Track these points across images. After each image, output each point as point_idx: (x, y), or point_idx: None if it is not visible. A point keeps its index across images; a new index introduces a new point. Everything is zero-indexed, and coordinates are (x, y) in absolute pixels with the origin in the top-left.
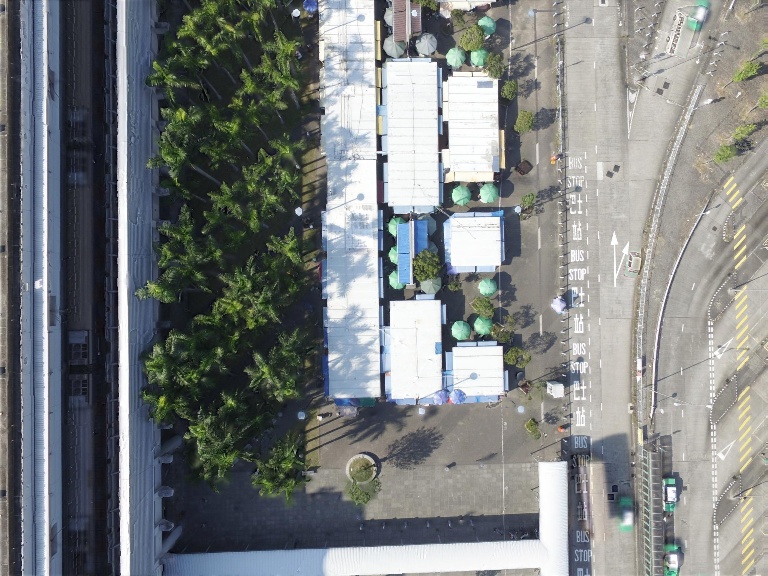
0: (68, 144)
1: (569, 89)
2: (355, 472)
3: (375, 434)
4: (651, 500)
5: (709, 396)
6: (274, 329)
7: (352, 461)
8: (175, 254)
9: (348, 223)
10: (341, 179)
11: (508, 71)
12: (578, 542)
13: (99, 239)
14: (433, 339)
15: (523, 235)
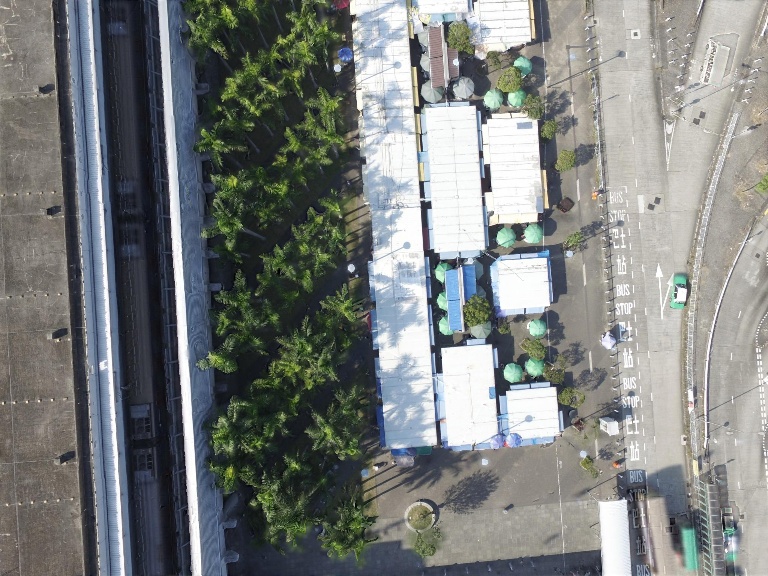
0: (118, 215)
1: (606, 123)
2: (414, 520)
3: (431, 481)
4: (711, 532)
5: (761, 423)
6: (330, 386)
7: (410, 509)
8: (232, 320)
9: (395, 272)
10: (386, 228)
11: (545, 109)
12: None
13: (154, 309)
14: (486, 384)
15: (568, 272)
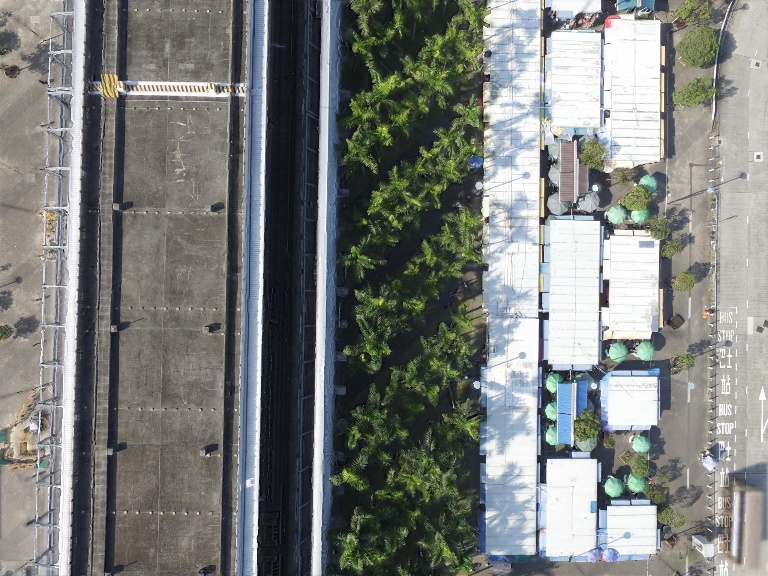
0: None
1: (722, 243)
2: None
3: None
4: None
5: None
6: (443, 495)
7: None
8: (362, 433)
9: (508, 381)
10: (503, 337)
11: None
12: None
13: (286, 414)
14: (589, 498)
15: (673, 389)
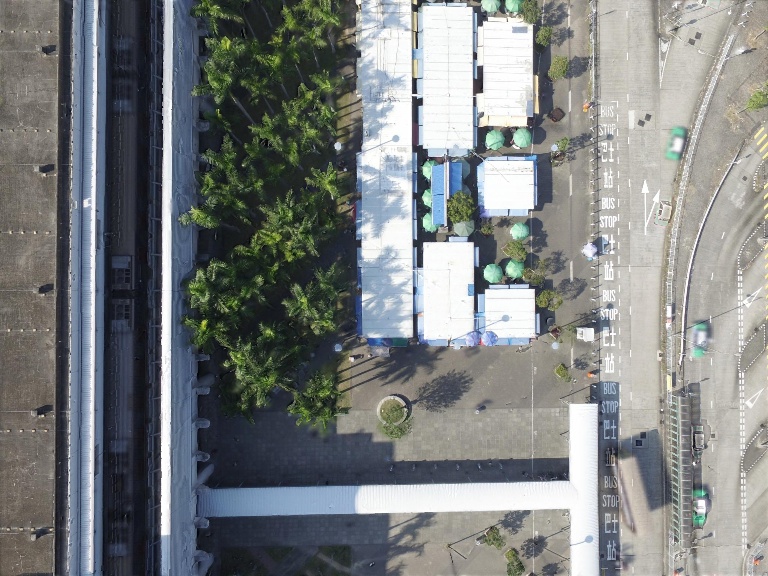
0: (112, 74)
1: (602, 38)
2: None
3: (406, 376)
4: (680, 444)
5: (738, 344)
6: (311, 264)
7: (383, 402)
8: (217, 183)
9: (383, 165)
10: (377, 121)
11: (541, 19)
12: (606, 487)
13: (142, 168)
14: (466, 281)
15: (555, 182)
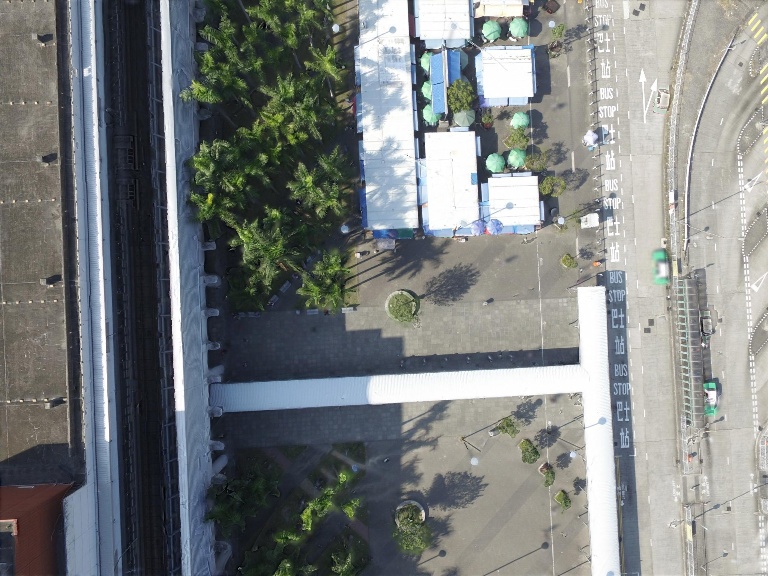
0: None
1: None
2: None
3: (413, 271)
4: (688, 326)
5: (741, 229)
6: (313, 151)
7: (391, 297)
8: (216, 64)
9: (381, 57)
10: (373, 13)
11: None
12: (616, 376)
13: (140, 52)
14: (469, 170)
15: (553, 73)
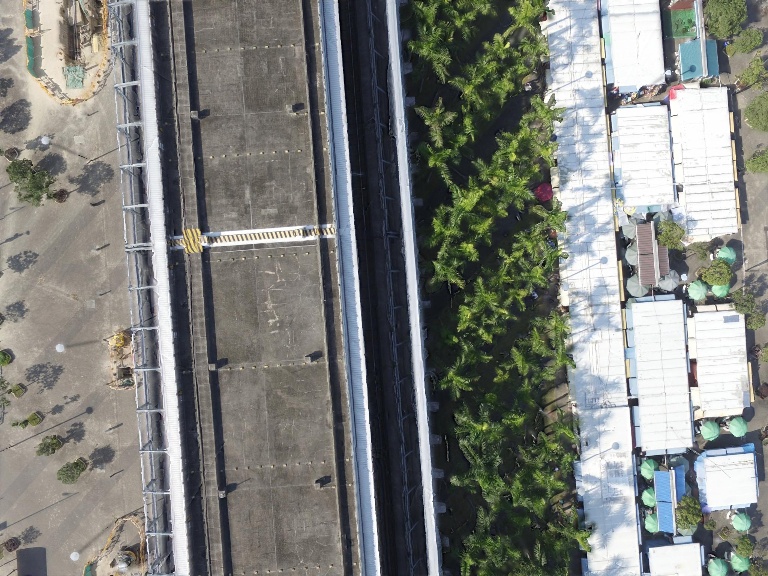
0: None
1: None
2: None
3: None
4: None
5: None
6: None
7: None
8: None
9: (603, 472)
10: (594, 428)
11: None
12: None
13: None
14: None
15: (766, 459)
